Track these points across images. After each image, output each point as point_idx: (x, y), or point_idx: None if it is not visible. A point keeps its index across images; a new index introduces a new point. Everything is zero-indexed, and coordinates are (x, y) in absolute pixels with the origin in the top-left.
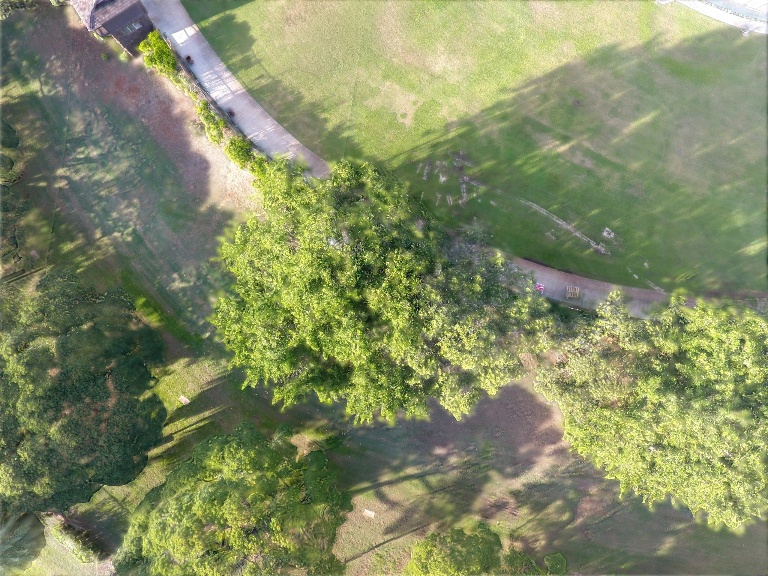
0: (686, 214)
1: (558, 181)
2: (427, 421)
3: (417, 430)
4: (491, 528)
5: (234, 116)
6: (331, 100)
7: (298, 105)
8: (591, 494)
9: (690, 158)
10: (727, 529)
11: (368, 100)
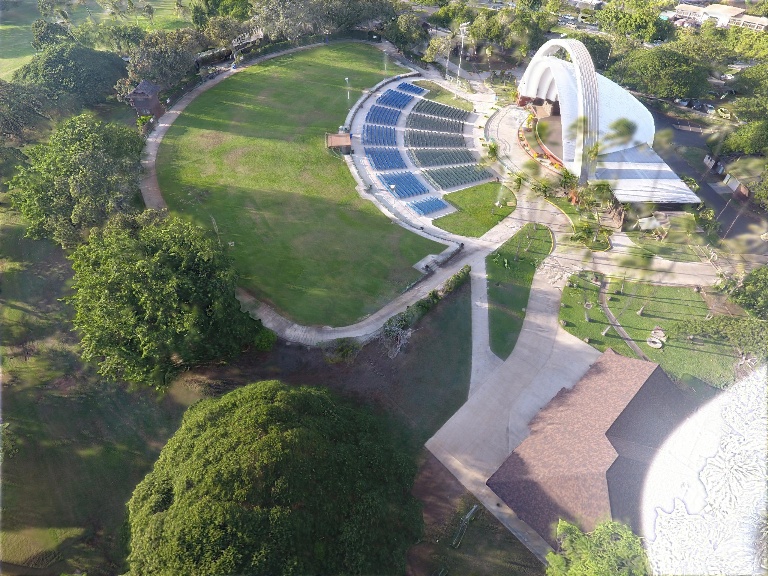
0: (278, 258)
1: (235, 218)
2: (58, 283)
3: (49, 285)
4: (5, 357)
5: (145, 146)
6: (184, 158)
7: (171, 153)
8: (75, 376)
9: (309, 243)
10: (117, 461)
11: (198, 164)
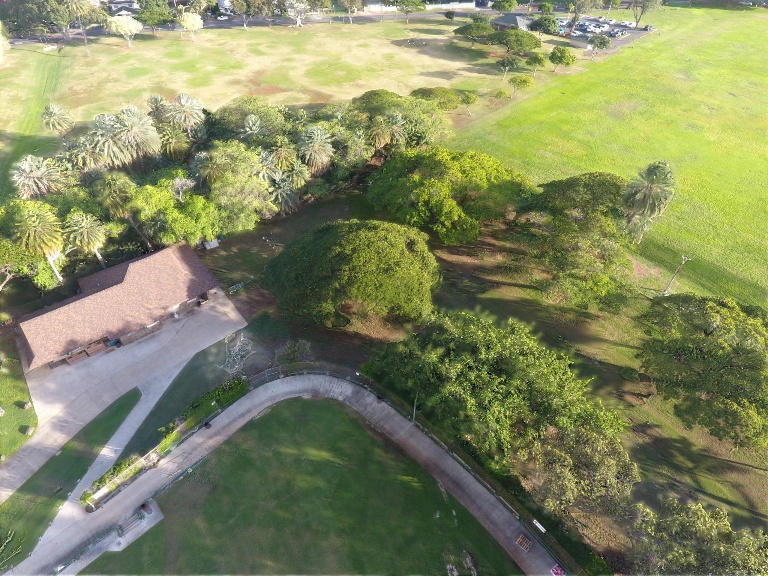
0: (368, 531)
1: None
2: None
3: None
4: (656, 423)
5: None
6: None
7: None
8: None
9: None
10: None
11: None
